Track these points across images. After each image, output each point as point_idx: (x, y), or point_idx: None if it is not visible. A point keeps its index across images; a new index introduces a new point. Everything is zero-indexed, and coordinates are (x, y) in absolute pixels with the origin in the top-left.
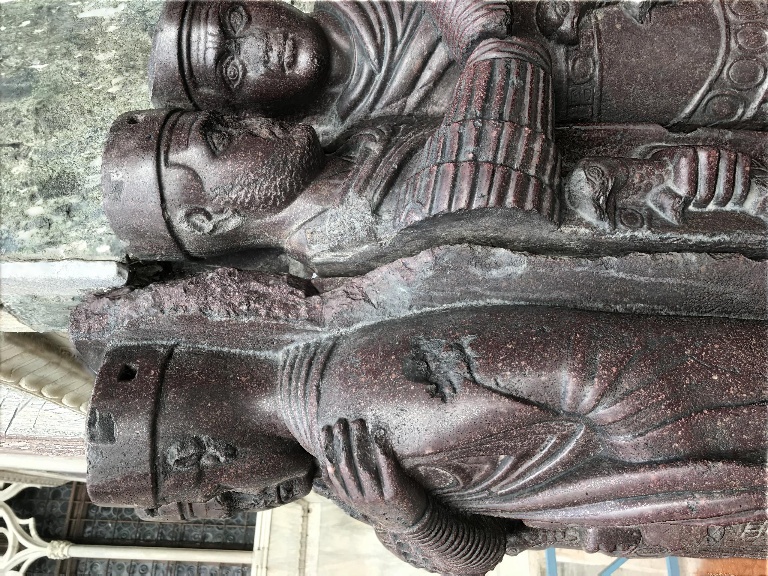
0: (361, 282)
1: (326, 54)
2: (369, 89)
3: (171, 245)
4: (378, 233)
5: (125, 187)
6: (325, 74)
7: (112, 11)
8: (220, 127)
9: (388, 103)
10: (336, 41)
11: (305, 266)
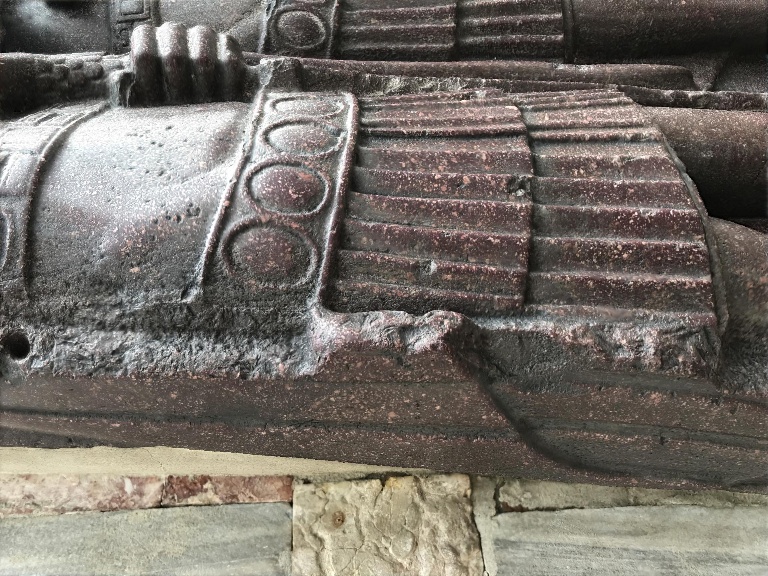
0: None
1: None
2: None
3: None
4: None
5: None
6: None
7: None
8: None
9: None
10: None
11: None
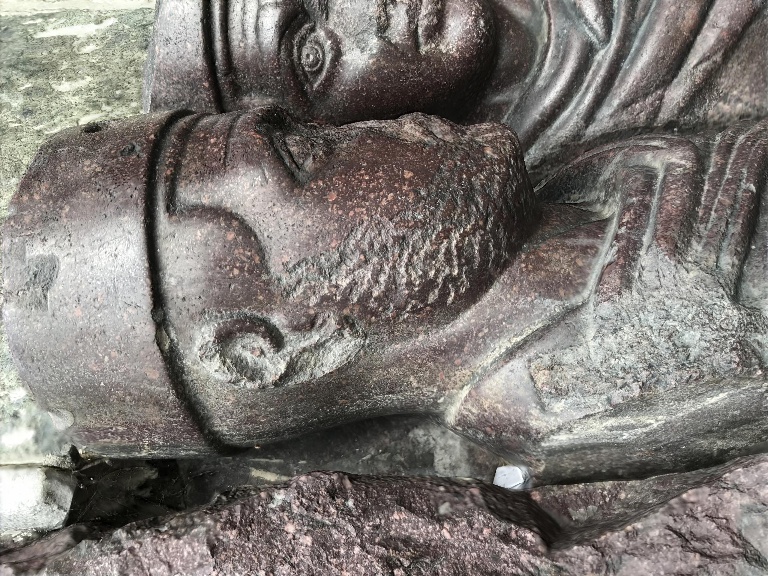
0: (718, 501)
1: (494, 19)
2: (582, 81)
3: (177, 419)
4: (766, 356)
5: (60, 270)
6: (490, 60)
7: (93, 29)
8: (301, 129)
9: (625, 103)
10: (503, 6)
11: (471, 451)
